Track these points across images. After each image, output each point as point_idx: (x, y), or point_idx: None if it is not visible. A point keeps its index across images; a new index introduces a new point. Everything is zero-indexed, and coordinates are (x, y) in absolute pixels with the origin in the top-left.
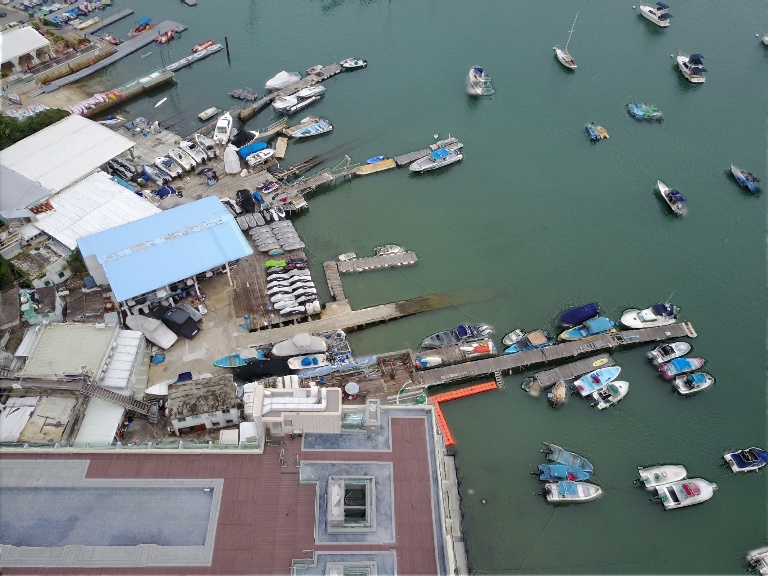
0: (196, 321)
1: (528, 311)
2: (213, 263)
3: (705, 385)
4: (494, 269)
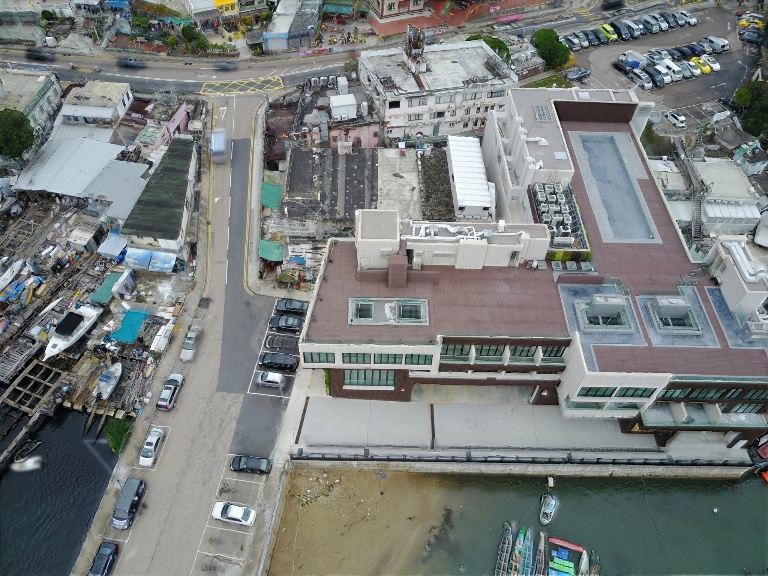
0: None
1: None
2: None
3: None
4: None
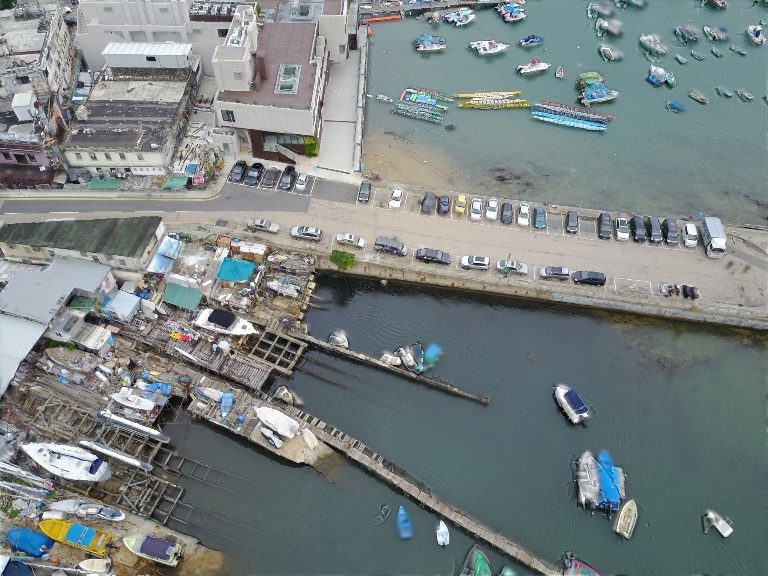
0: None
1: None
2: None
3: (520, 17)
4: None
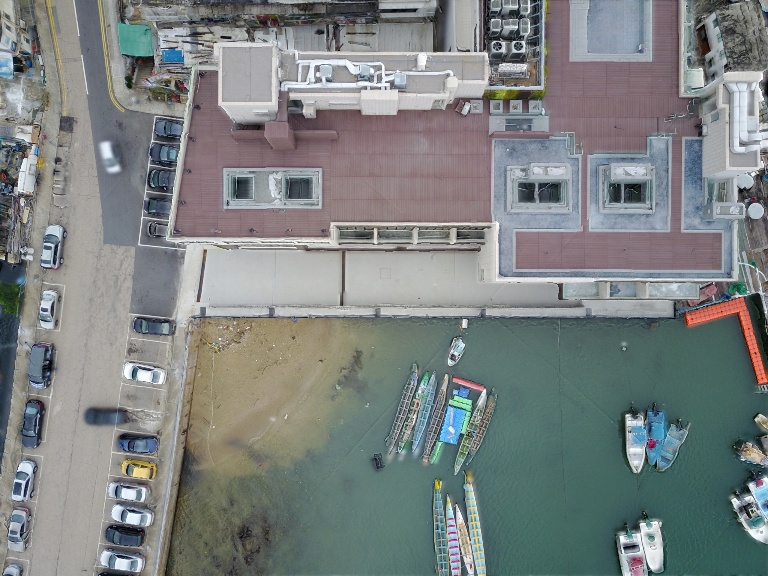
0: None
1: None
2: None
3: None
4: None
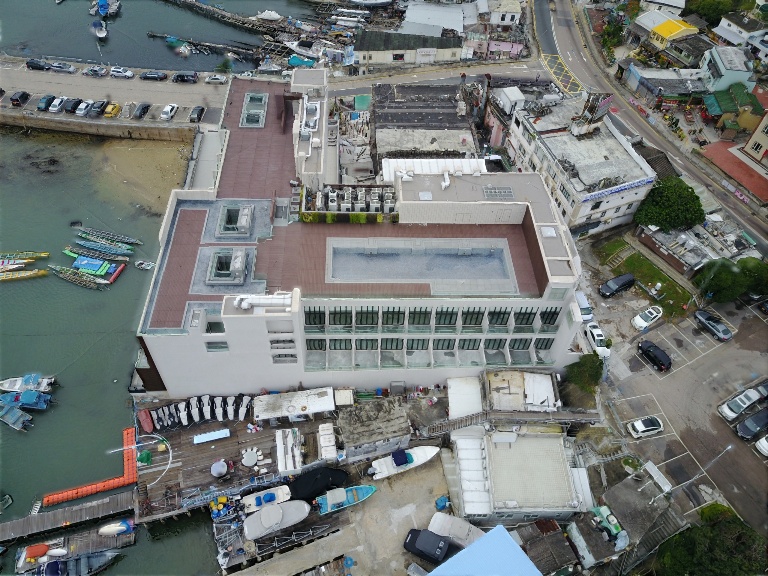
0: None
1: None
2: None
3: None
4: None
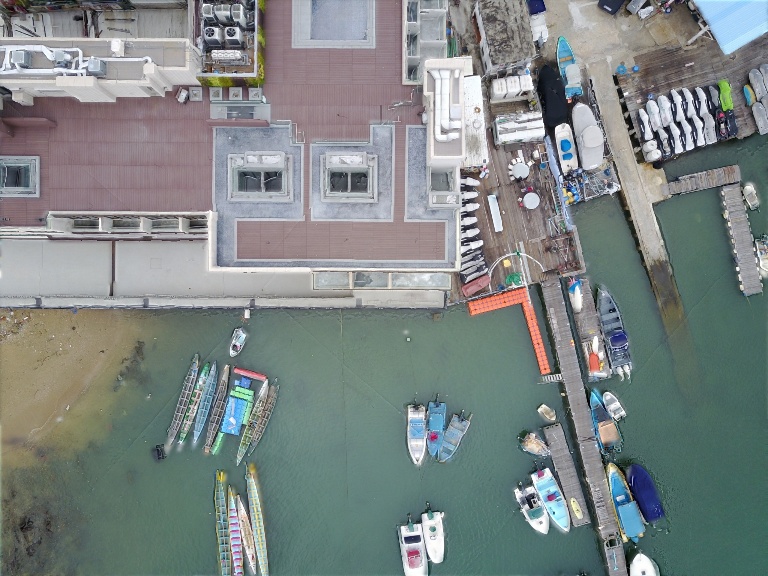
0: (627, 7)
1: (659, 435)
2: (704, 3)
3: None
4: (735, 403)
